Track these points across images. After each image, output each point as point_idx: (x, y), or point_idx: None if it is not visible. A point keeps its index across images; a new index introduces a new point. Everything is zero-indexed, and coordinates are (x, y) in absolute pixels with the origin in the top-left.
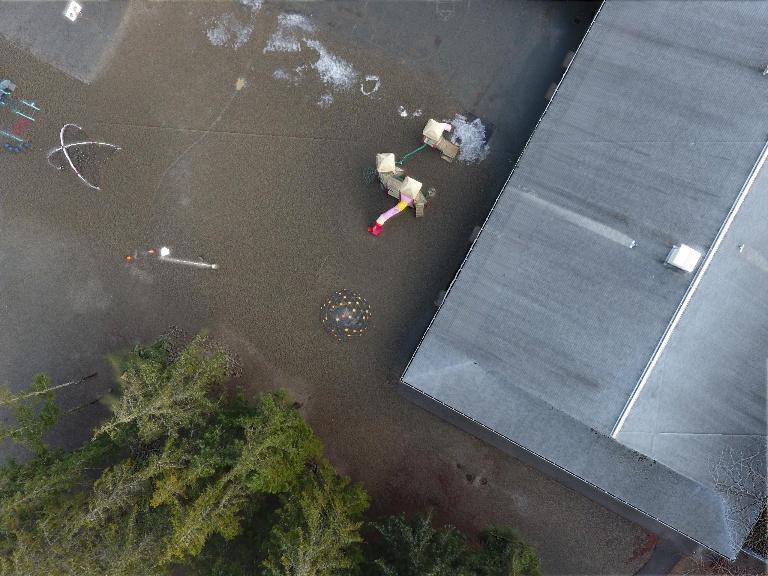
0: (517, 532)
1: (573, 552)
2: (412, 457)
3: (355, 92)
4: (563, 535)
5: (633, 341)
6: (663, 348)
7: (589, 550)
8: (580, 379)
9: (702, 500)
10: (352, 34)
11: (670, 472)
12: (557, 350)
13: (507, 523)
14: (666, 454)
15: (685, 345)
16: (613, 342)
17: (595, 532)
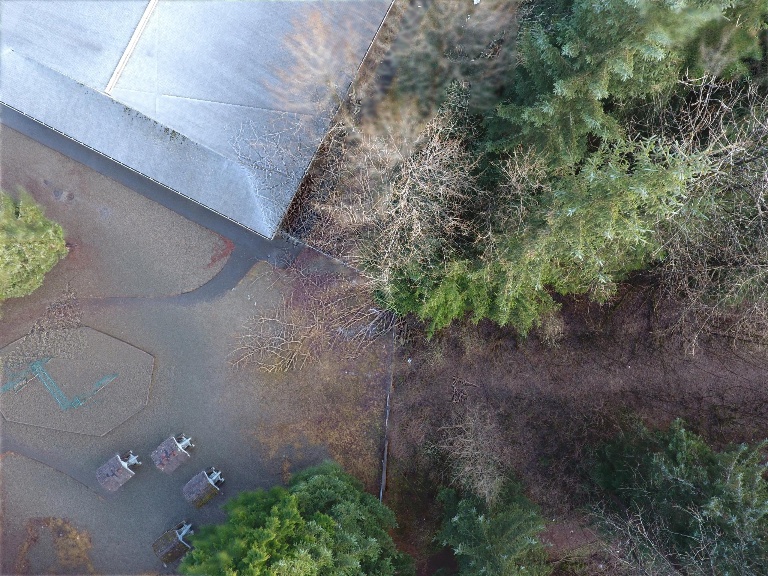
0: (101, 243)
1: (155, 260)
2: (0, 175)
3: None
4: (145, 245)
5: (131, 4)
6: (154, 5)
7: (170, 258)
8: (88, 46)
9: (231, 176)
10: None
11: (199, 149)
12: (74, 24)
13: (92, 235)
14: (174, 118)
15: (181, 6)
16: (117, 8)
17: (175, 240)
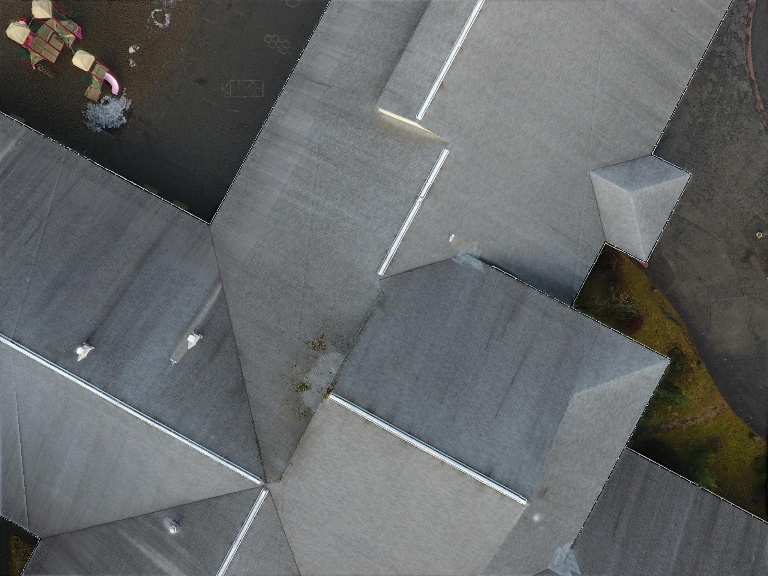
0: None
1: None
2: None
3: (154, 4)
4: None
5: None
6: None
7: None
8: None
9: None
10: (211, 0)
11: None
12: None
13: None
14: None
15: None
16: None
17: None
